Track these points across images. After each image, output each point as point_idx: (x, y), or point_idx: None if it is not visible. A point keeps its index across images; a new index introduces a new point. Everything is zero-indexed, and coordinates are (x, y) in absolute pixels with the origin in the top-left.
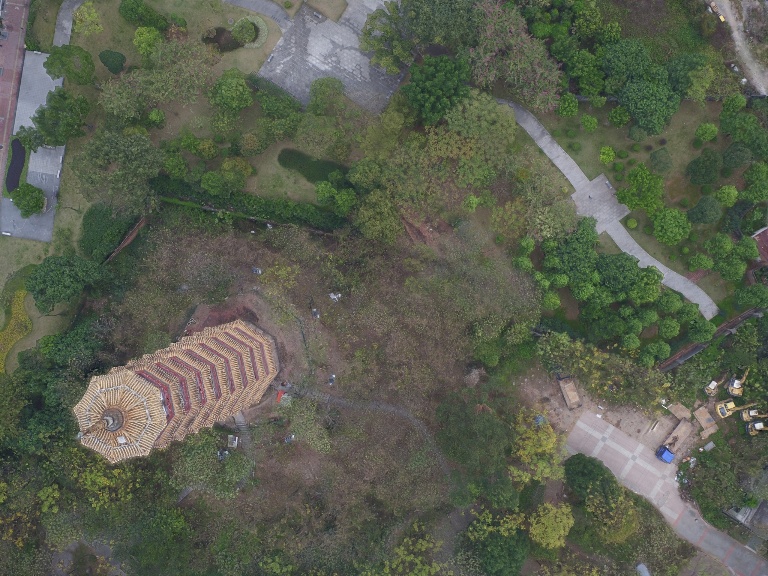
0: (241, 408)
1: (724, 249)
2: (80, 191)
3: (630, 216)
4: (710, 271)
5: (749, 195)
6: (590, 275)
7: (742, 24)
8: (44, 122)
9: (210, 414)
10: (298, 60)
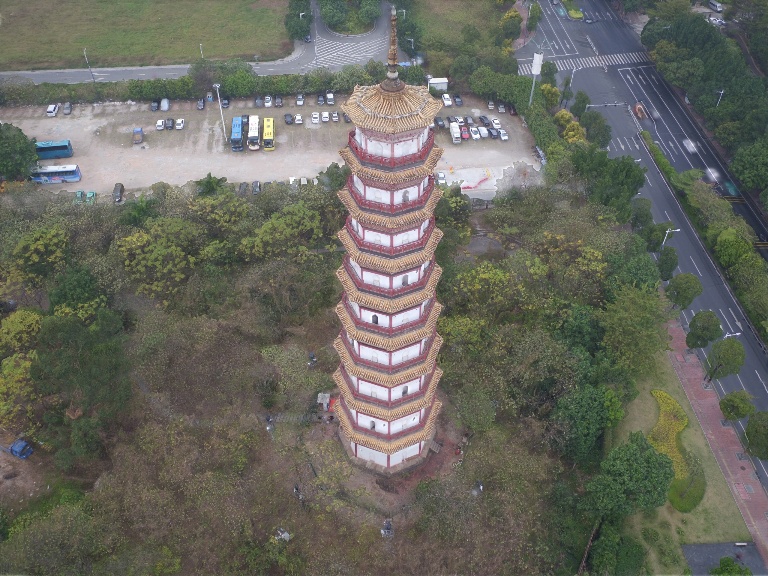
0: None
1: None
2: None
3: None
4: None
5: None
6: None
7: None
8: None
9: None
10: None
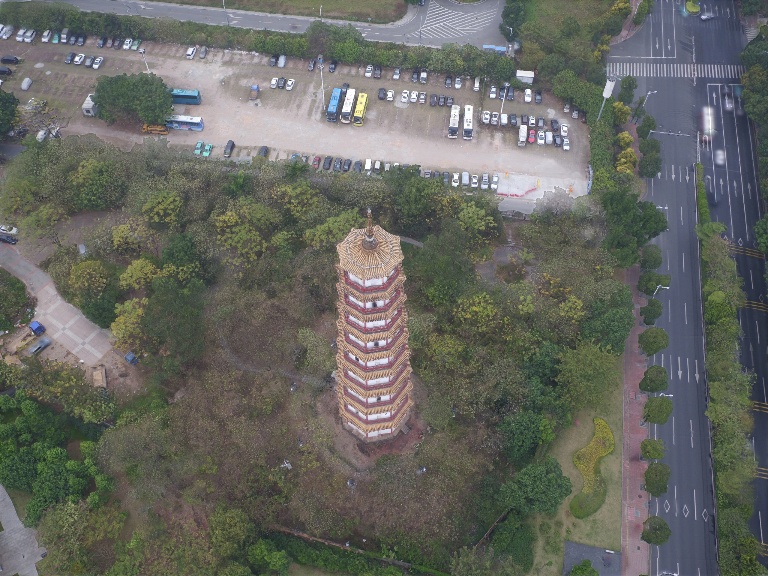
0: None
1: None
2: None
3: None
4: None
5: None
6: None
7: None
8: None
9: None
10: None
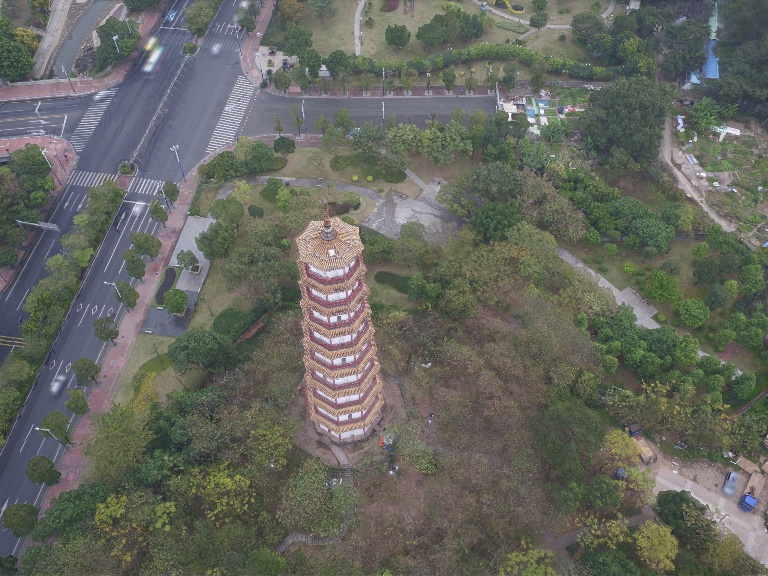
0: (360, 409)
1: (741, 320)
2: (226, 281)
3: (658, 314)
4: (736, 353)
5: (747, 286)
6: (638, 341)
7: (704, 199)
8: (204, 241)
9: (358, 344)
10: (388, 220)
